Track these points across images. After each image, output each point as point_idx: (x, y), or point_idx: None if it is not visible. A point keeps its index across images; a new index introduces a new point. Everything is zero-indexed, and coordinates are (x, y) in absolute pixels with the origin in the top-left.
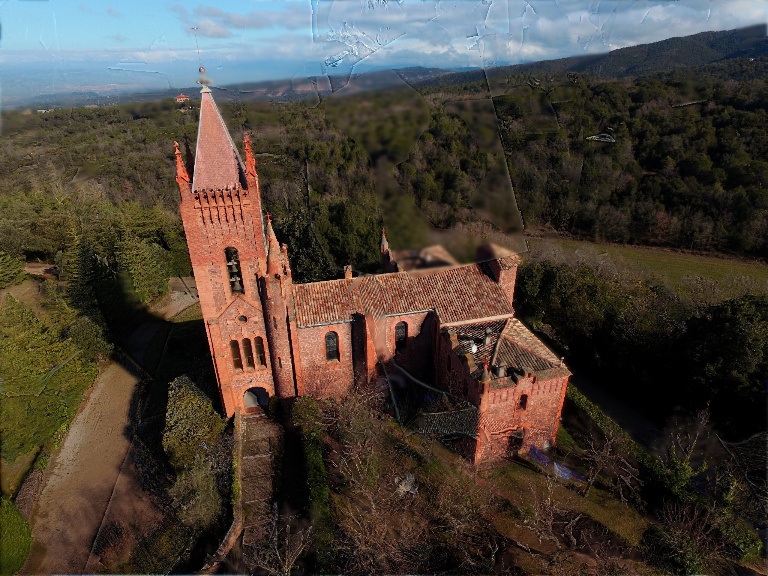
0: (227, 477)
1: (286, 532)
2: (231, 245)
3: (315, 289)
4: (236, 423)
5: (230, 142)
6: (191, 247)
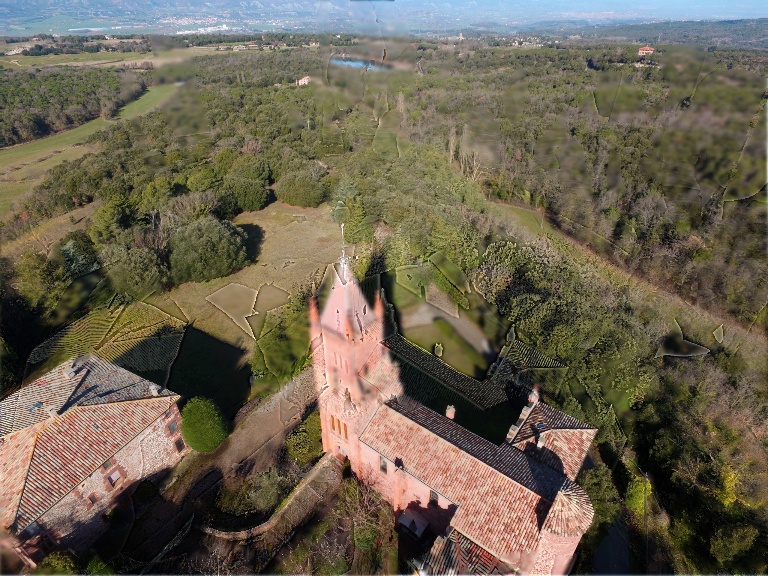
0: (289, 491)
1: (281, 555)
2: None
3: None
4: (321, 460)
5: None
6: None
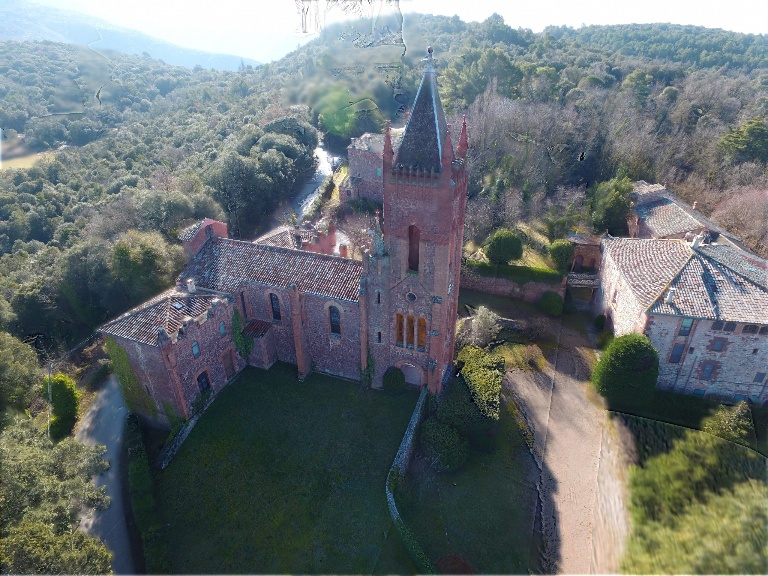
0: None
1: None
2: None
3: None
4: None
5: None
6: None
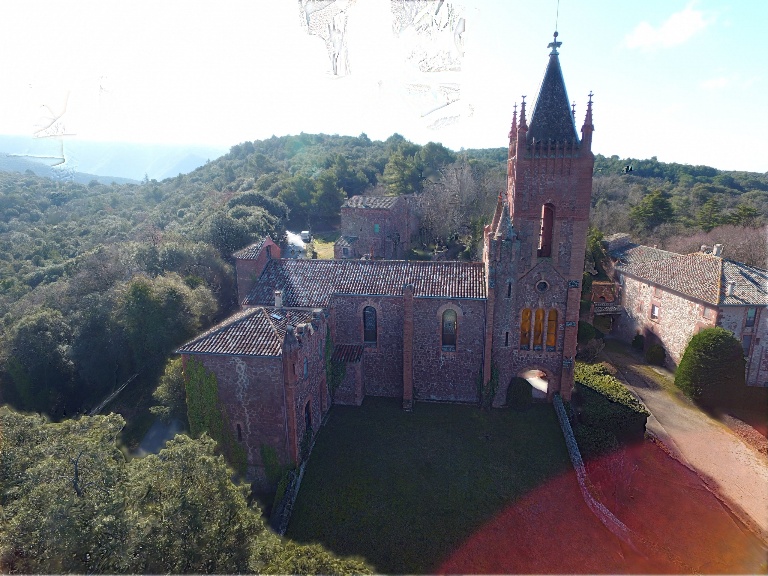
0: None
1: None
2: None
3: None
4: None
5: None
6: None
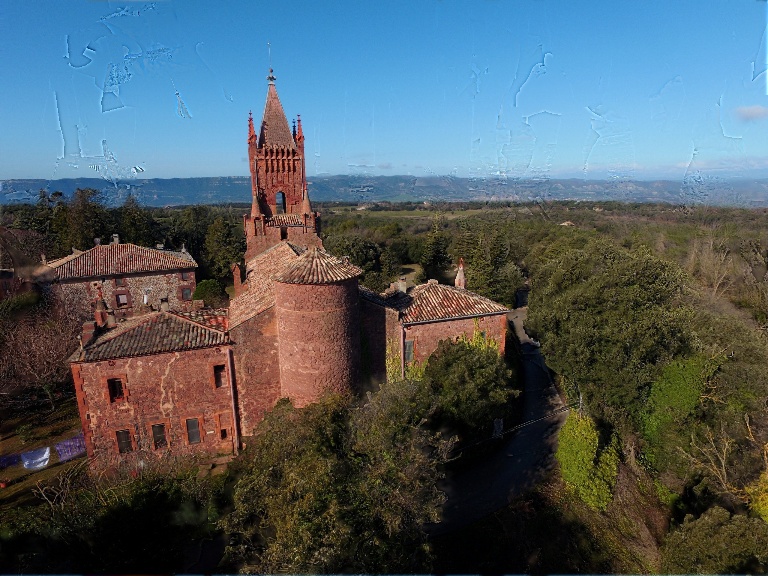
0: None
1: None
2: None
3: (281, 248)
4: None
5: (264, 117)
6: None
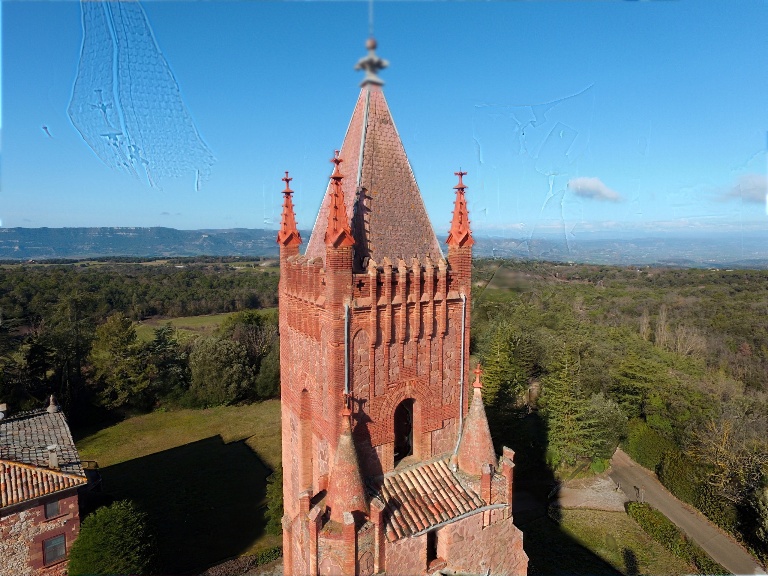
0: None
1: None
2: (308, 387)
3: None
4: None
5: (359, 173)
6: (282, 363)
